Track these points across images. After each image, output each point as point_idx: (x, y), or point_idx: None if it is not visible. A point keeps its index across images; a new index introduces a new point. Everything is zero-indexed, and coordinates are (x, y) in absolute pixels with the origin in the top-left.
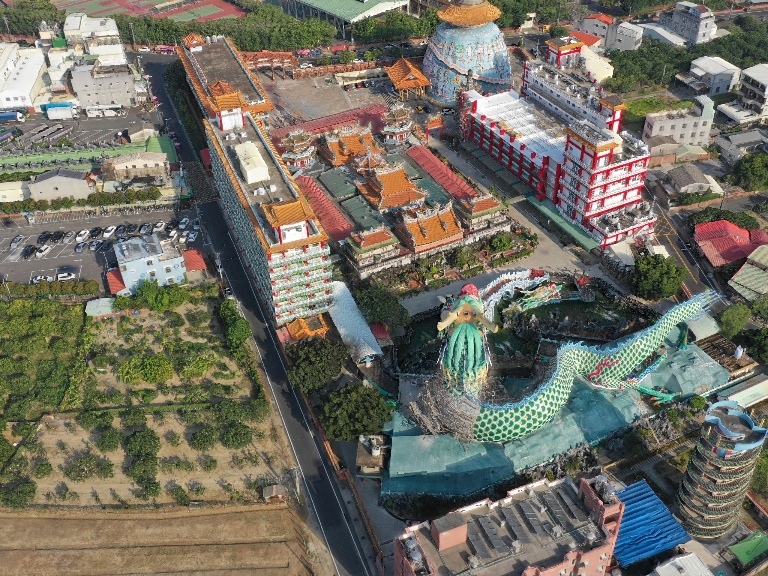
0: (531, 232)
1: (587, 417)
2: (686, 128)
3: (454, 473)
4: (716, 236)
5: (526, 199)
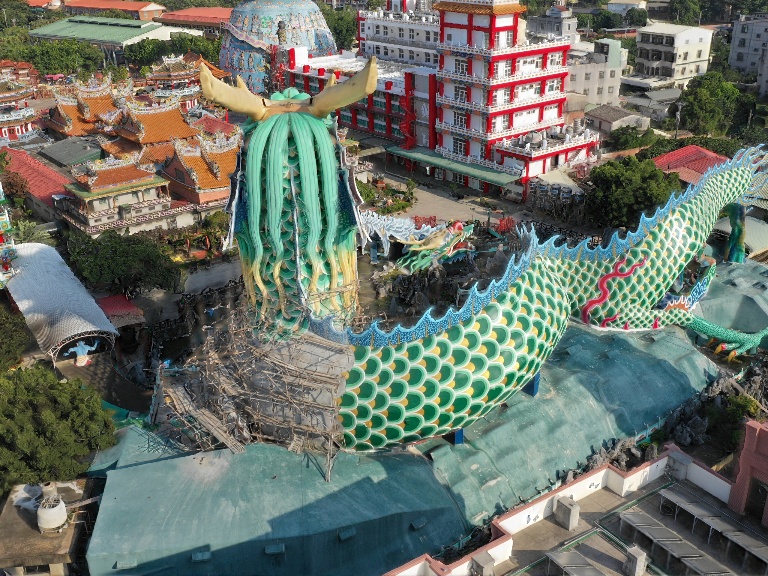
0: (401, 190)
1: (611, 379)
2: (590, 80)
3: (295, 538)
4: (690, 160)
5: (386, 151)
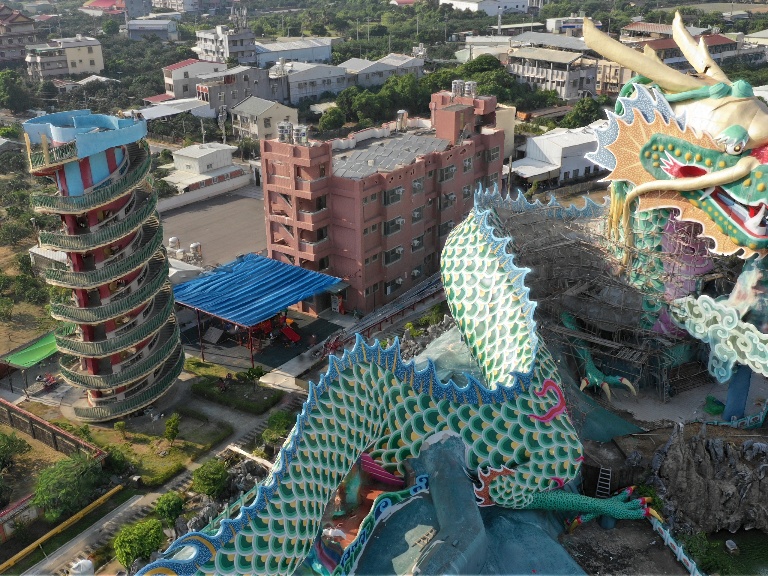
0: None
1: None
2: None
3: None
4: None
5: None
